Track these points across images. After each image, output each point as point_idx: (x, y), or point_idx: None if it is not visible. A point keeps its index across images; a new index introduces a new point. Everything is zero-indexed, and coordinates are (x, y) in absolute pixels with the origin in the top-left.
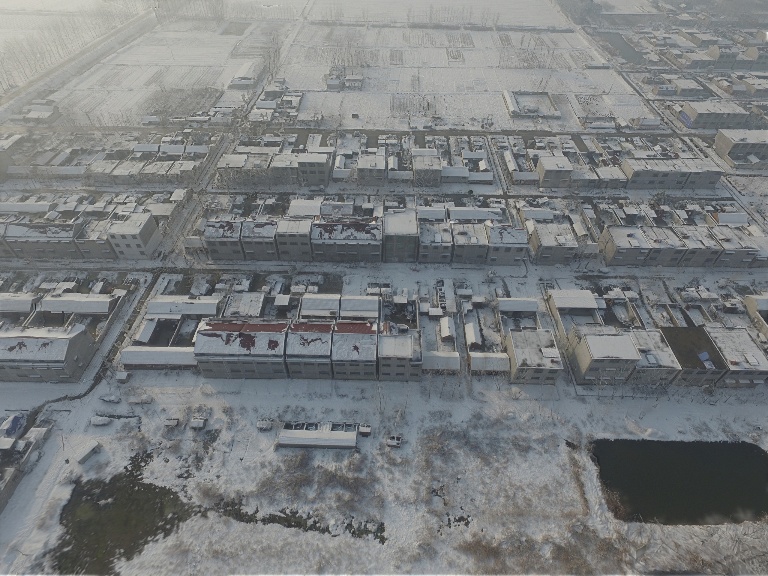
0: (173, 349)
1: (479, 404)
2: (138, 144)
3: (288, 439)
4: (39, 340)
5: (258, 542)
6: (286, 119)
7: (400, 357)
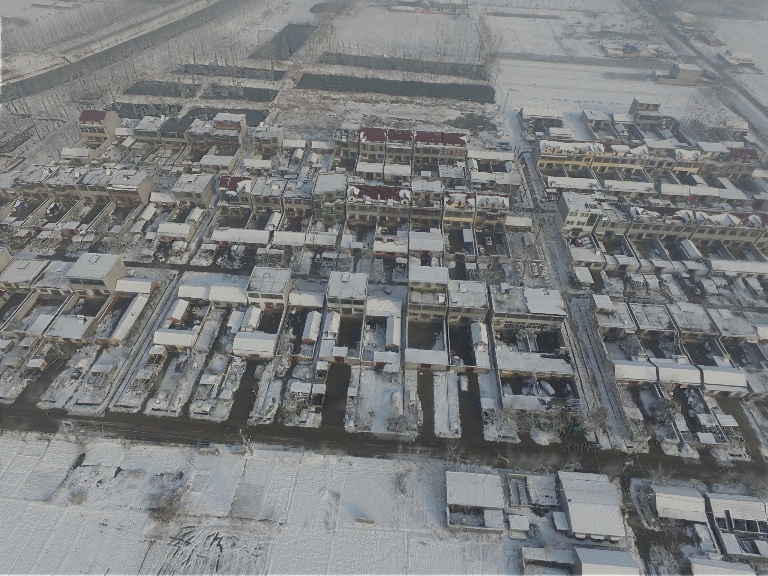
0: (484, 154)
1: (308, 137)
2: (740, 373)
3: (407, 129)
4: (557, 139)
5: (413, 116)
6: (531, 506)
7: (349, 123)
